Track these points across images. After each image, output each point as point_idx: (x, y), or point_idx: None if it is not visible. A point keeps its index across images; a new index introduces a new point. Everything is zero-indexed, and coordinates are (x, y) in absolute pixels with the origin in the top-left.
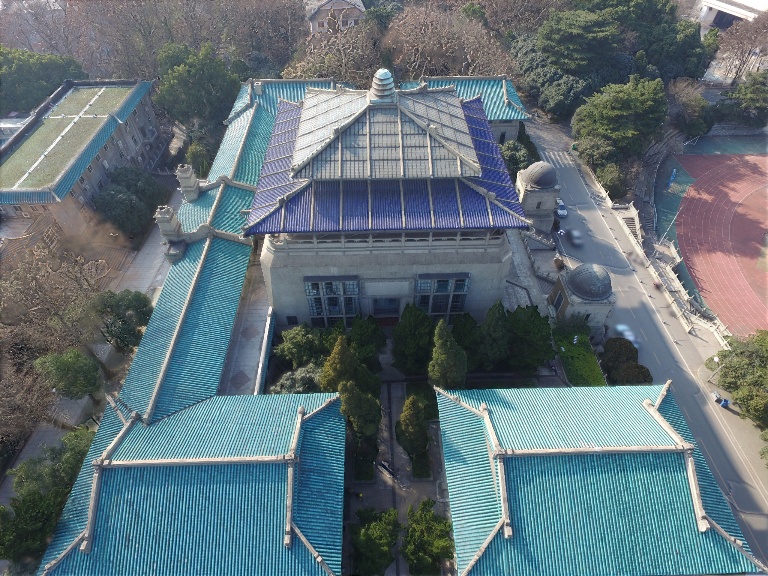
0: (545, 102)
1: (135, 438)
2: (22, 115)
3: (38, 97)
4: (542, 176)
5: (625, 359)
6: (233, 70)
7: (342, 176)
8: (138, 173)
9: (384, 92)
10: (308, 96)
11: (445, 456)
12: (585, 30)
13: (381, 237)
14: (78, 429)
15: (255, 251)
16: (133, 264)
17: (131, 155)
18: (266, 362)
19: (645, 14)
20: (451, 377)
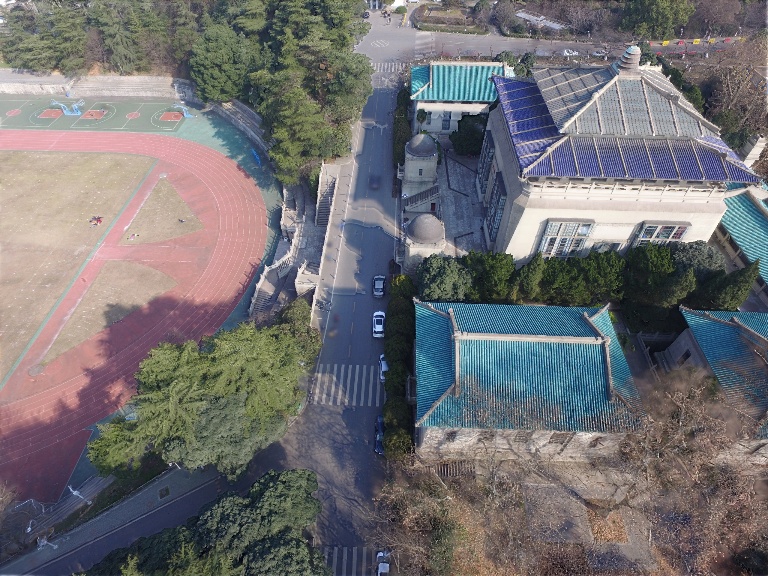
0: None
1: None
2: None
3: None
4: None
5: None
6: None
7: None
8: None
9: None
10: None
11: None
12: None
13: None
14: None
15: None
16: None
17: None
18: None
19: None
20: None
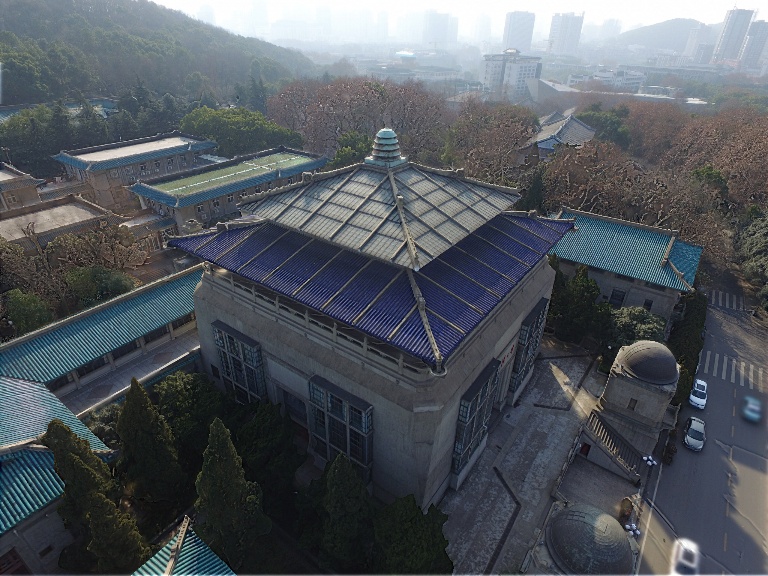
0: (767, 297)
1: None
2: None
3: (255, 151)
4: (644, 360)
5: None
6: None
7: (277, 219)
8: None
9: (379, 153)
10: None
11: None
12: None
13: (289, 305)
14: None
15: None
16: None
17: None
18: None
19: None
20: None
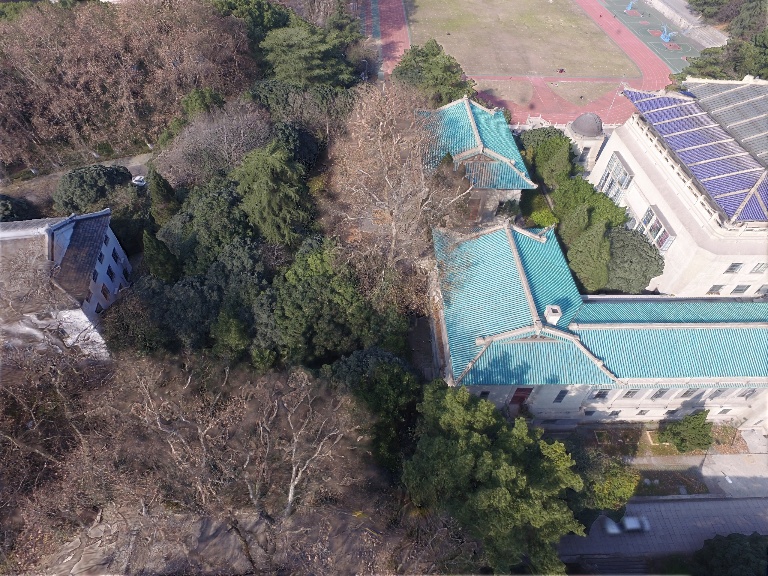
0: None
1: None
2: None
3: None
4: None
5: None
6: (369, 422)
7: None
8: None
9: None
10: None
11: None
12: None
13: None
14: None
15: None
16: None
17: None
18: None
19: None
20: None
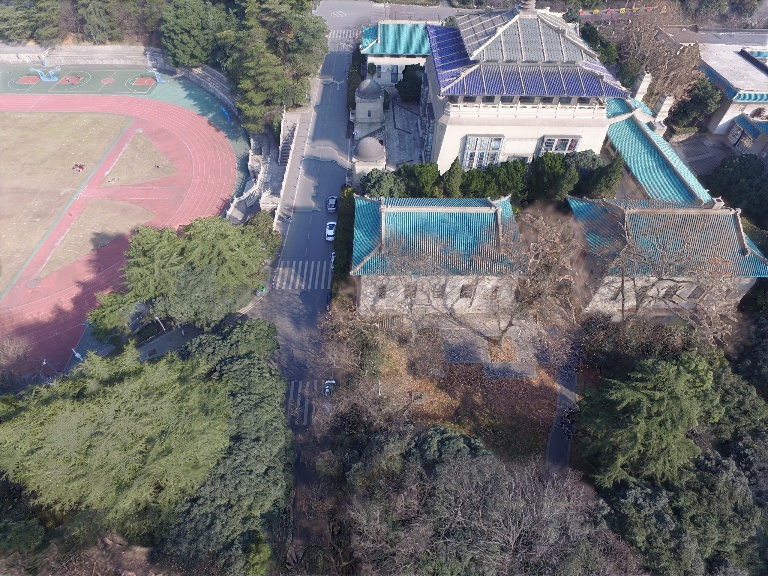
0: None
1: None
2: None
3: None
4: None
5: None
6: None
7: None
8: None
9: None
10: None
11: None
12: None
13: None
14: None
15: None
16: None
17: None
18: None
19: None
20: None
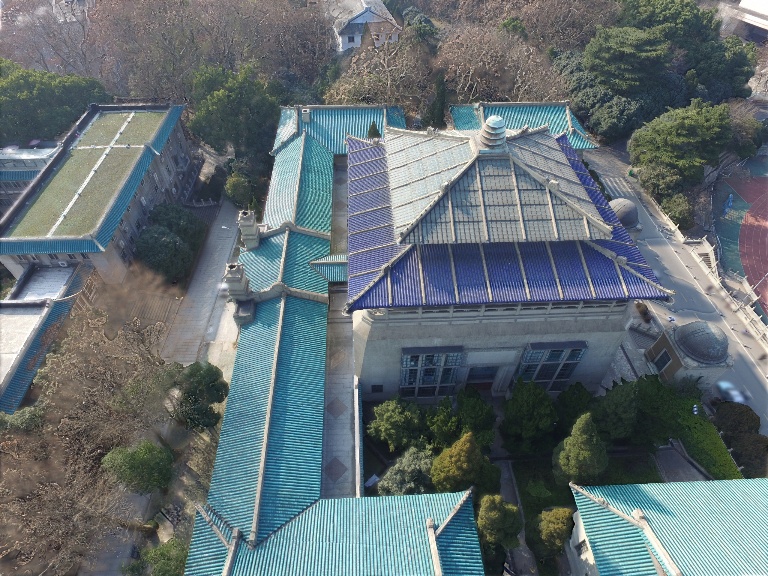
0: (596, 124)
1: (245, 569)
2: (43, 143)
3: (62, 124)
4: (625, 215)
5: (747, 429)
6: (268, 91)
7: (457, 240)
8: (178, 210)
9: (496, 142)
10: (389, 137)
11: (601, 575)
12: (636, 49)
13: (494, 306)
14: (148, 528)
15: (328, 307)
16: (179, 314)
17: (165, 187)
18: (361, 446)
19: (690, 30)
20: (589, 472)
